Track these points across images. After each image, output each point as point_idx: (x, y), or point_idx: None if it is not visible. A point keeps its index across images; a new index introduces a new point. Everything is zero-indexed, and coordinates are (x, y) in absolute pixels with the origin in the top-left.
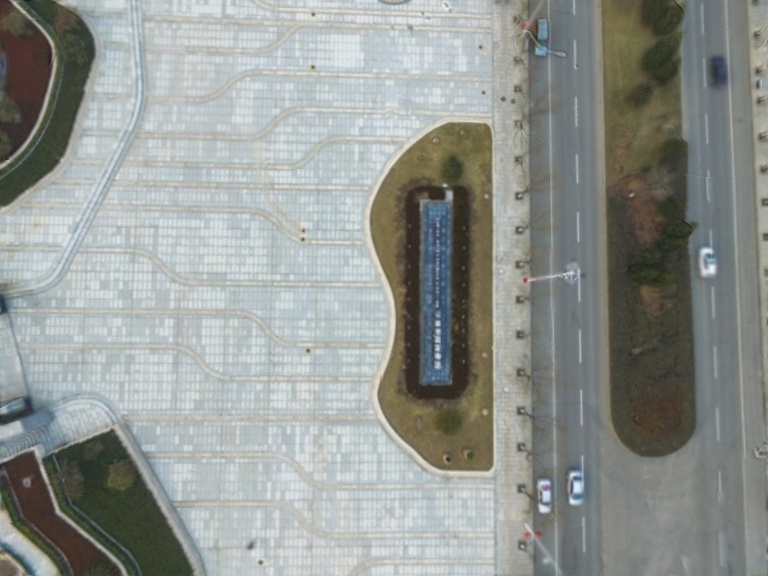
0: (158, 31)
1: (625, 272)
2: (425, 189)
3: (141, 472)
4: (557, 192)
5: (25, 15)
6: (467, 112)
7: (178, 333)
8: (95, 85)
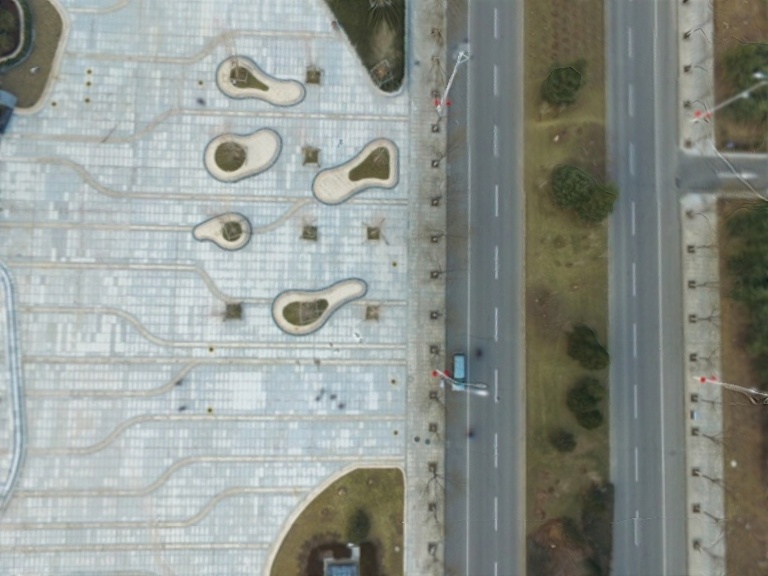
0: (40, 374)
1: None
2: (329, 547)
3: None
4: (474, 541)
5: None
6: (377, 455)
7: None
8: None
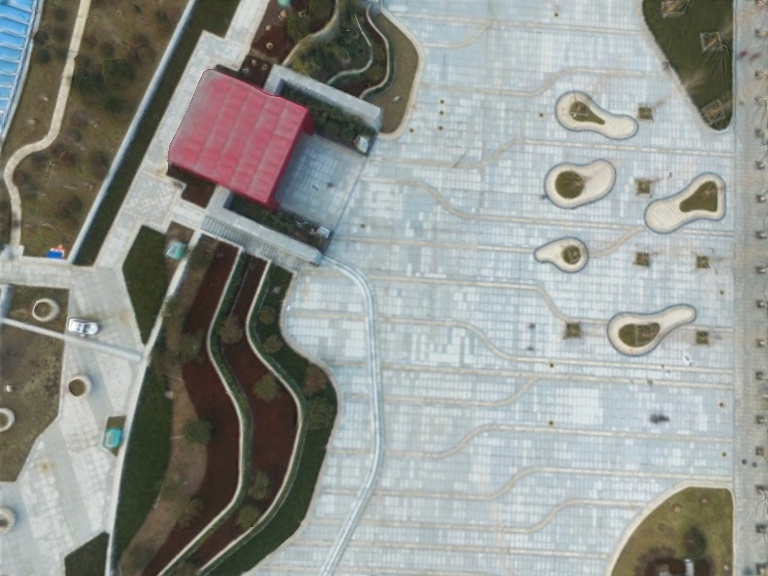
0: (396, 380)
1: None
2: (665, 562)
3: None
4: None
5: (272, 372)
6: (707, 475)
7: None
8: (335, 440)
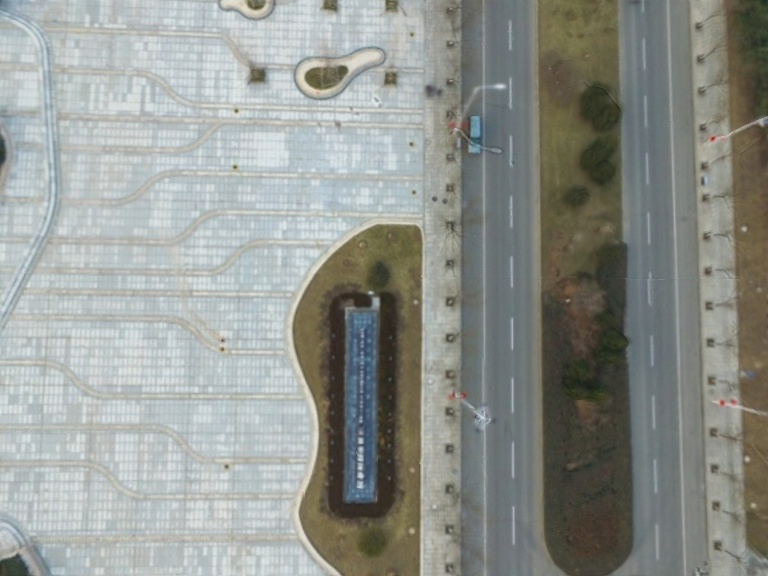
0: (73, 130)
1: (560, 383)
2: (351, 296)
3: None
4: (490, 297)
5: None
6: (396, 213)
7: (90, 449)
8: (6, 189)
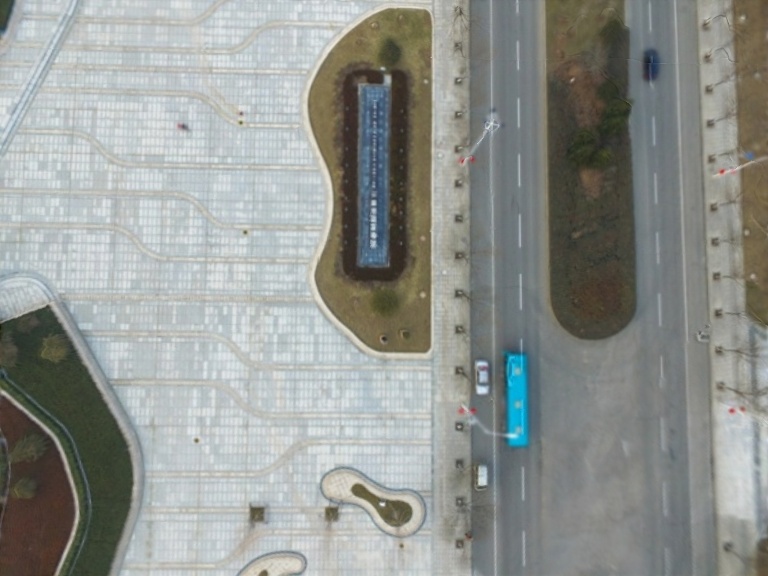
0: None
1: (565, 155)
2: (363, 73)
3: (77, 348)
4: (497, 78)
5: None
6: None
7: (115, 214)
8: None
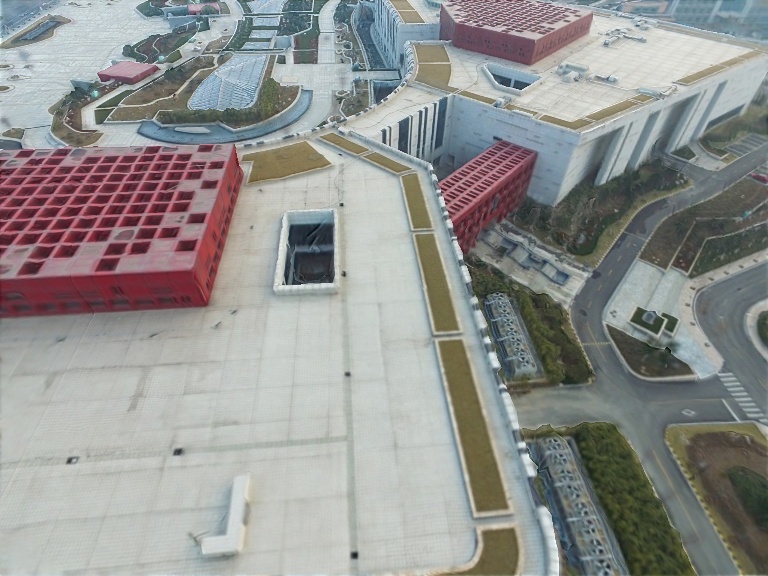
0: None
1: None
2: None
3: None
4: None
5: None
6: None
7: None
8: None
